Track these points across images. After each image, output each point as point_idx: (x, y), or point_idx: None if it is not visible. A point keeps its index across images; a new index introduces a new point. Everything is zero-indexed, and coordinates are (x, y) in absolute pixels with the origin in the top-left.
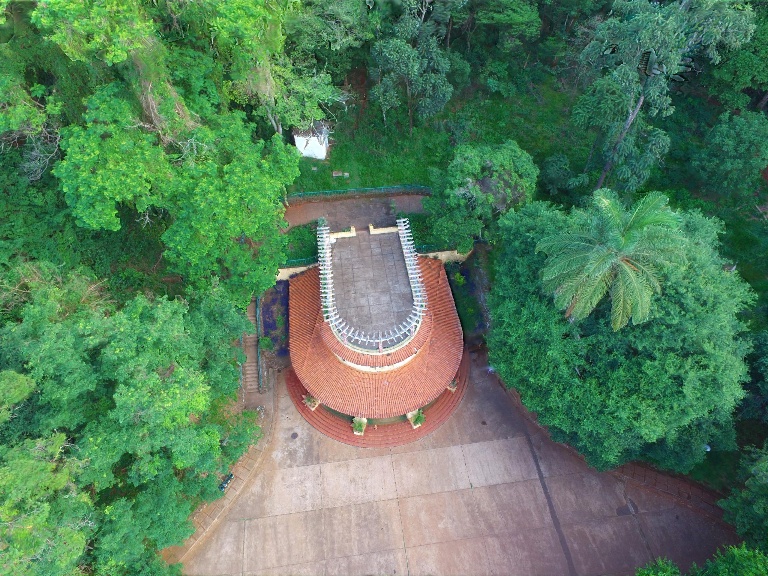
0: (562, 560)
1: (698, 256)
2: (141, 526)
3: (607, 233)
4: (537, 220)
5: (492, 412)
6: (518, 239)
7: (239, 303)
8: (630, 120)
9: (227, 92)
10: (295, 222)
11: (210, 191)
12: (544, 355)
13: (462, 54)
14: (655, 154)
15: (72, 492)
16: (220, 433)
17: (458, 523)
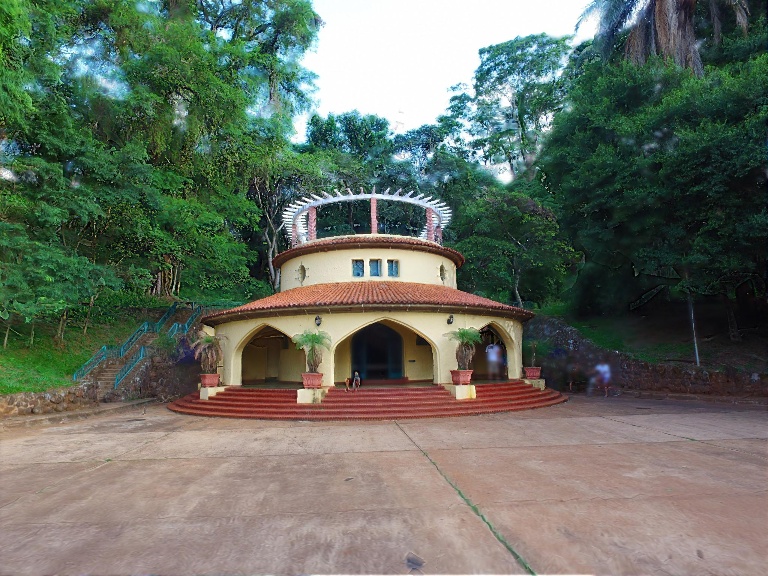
0: None
1: None
2: None
3: None
4: None
5: None
6: None
7: None
8: None
9: None
10: None
11: None
12: None
13: None
14: None
15: None
16: None
17: None
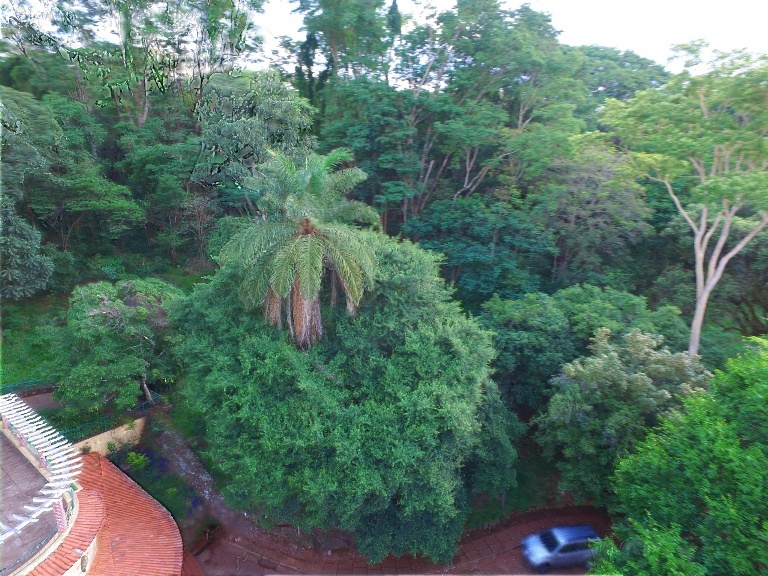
0: None
1: None
2: None
3: (290, 187)
4: None
5: None
6: None
7: None
8: None
9: None
10: None
11: None
12: (298, 405)
13: None
14: None
15: None
16: None
17: None
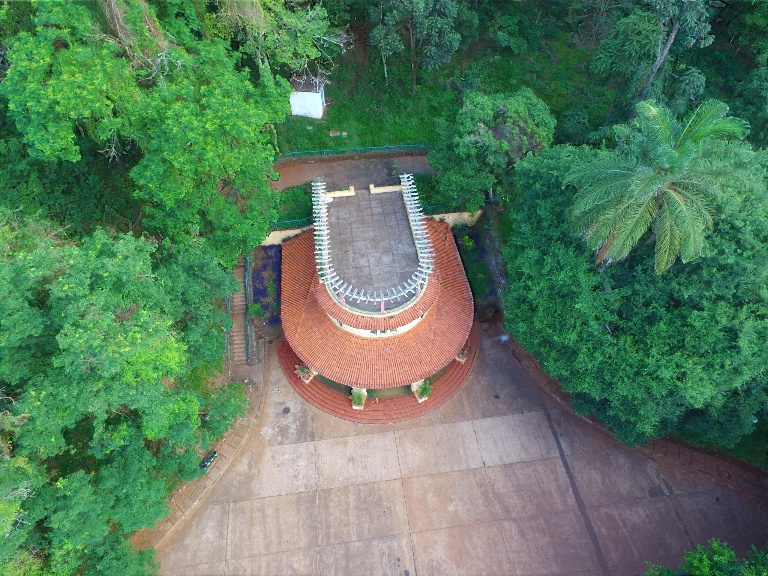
0: (589, 547)
1: (756, 186)
2: (103, 504)
3: (654, 150)
4: (560, 160)
5: (506, 385)
6: (539, 182)
7: (223, 260)
8: (658, 62)
9: (210, 25)
10: (289, 183)
11: (184, 115)
12: (570, 310)
13: (469, 8)
14: (689, 95)
15: (5, 454)
16: (200, 403)
17: (470, 505)
